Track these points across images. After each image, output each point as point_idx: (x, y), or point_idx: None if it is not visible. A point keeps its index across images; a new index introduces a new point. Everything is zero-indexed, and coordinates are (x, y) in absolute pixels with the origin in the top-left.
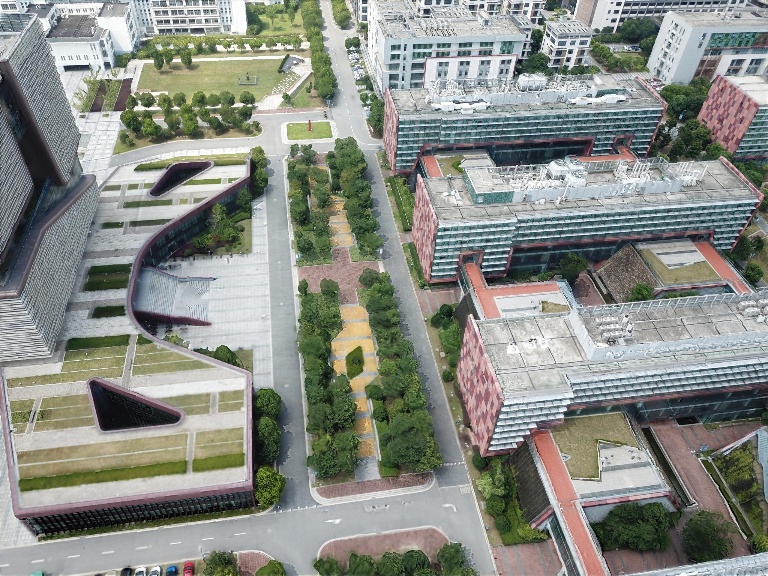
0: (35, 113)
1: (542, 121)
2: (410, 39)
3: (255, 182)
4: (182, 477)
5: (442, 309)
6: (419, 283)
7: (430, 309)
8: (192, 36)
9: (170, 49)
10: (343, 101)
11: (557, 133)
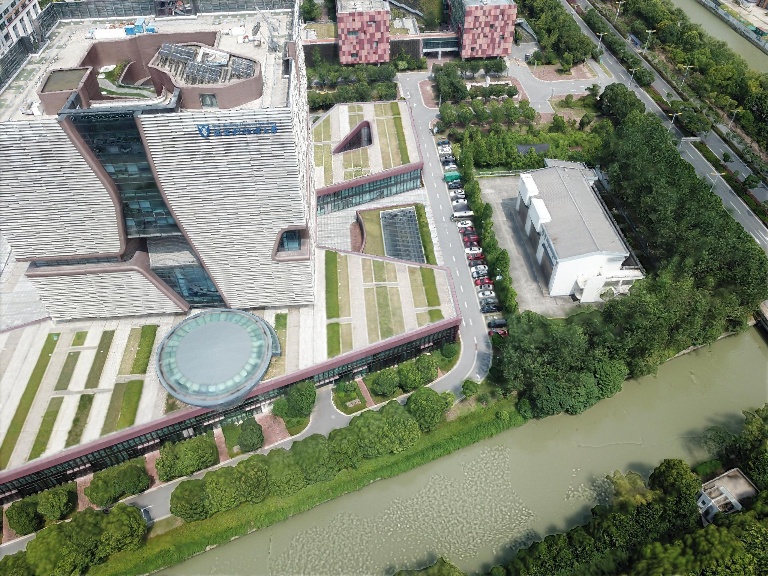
0: None
1: None
2: None
3: None
4: None
5: None
6: None
7: None
8: None
9: None
10: None
11: None
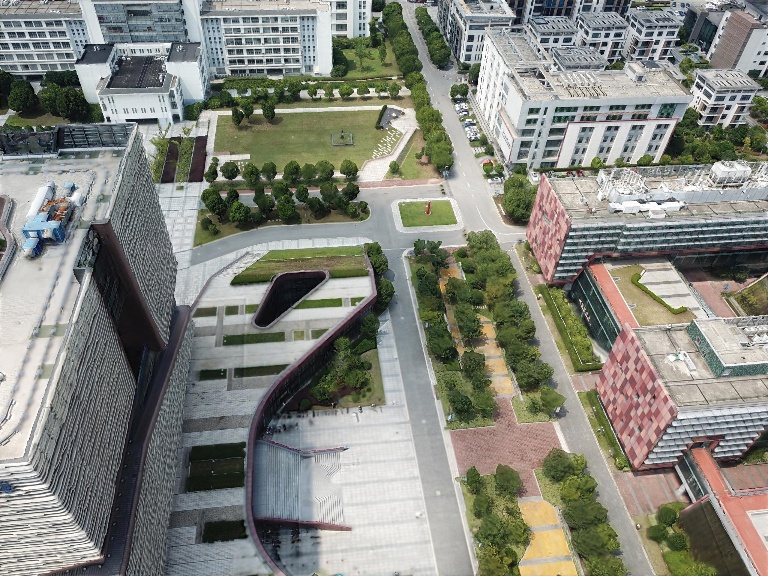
0: (137, 275)
1: (750, 226)
2: (553, 101)
3: (379, 297)
4: None
5: (664, 516)
6: (617, 463)
7: (639, 506)
8: (270, 79)
9: (251, 101)
10: (460, 170)
11: (765, 239)
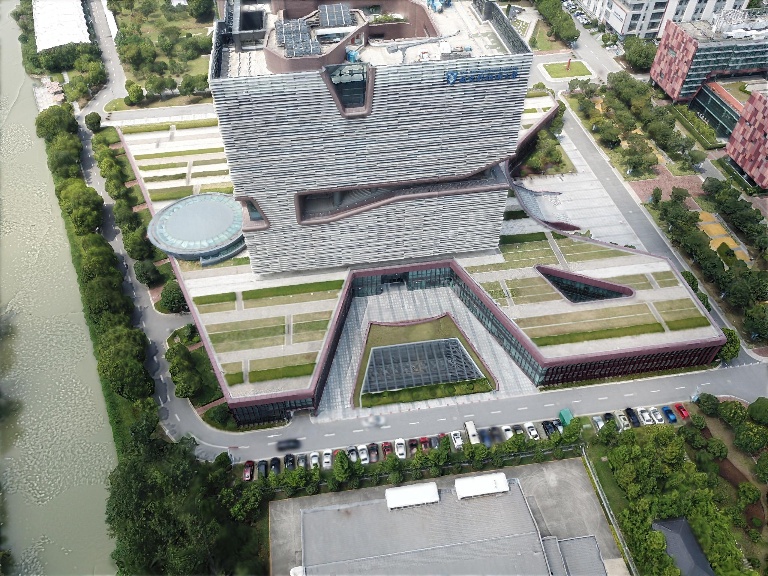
0: None
1: None
2: None
3: None
4: (663, 335)
5: None
6: (749, 191)
7: (767, 212)
8: None
9: None
10: (582, 43)
11: None
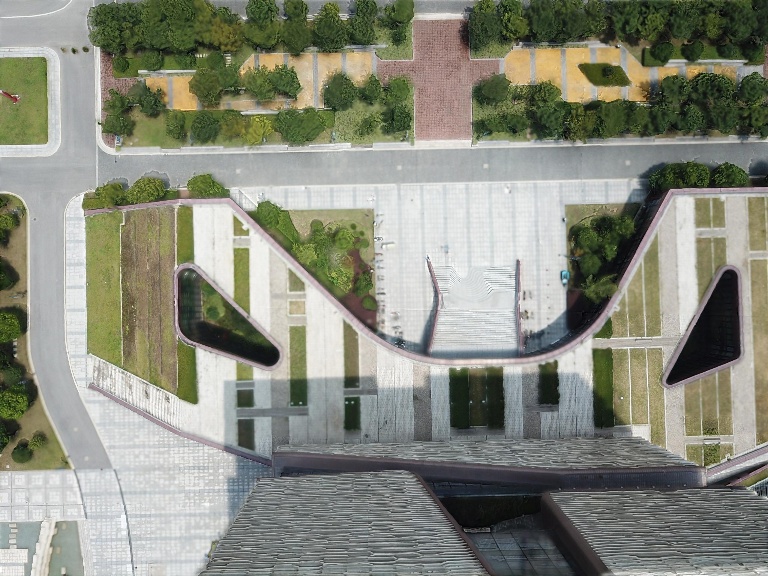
0: None
1: None
2: None
3: None
4: None
5: None
6: None
7: None
8: None
9: None
10: None
11: None
